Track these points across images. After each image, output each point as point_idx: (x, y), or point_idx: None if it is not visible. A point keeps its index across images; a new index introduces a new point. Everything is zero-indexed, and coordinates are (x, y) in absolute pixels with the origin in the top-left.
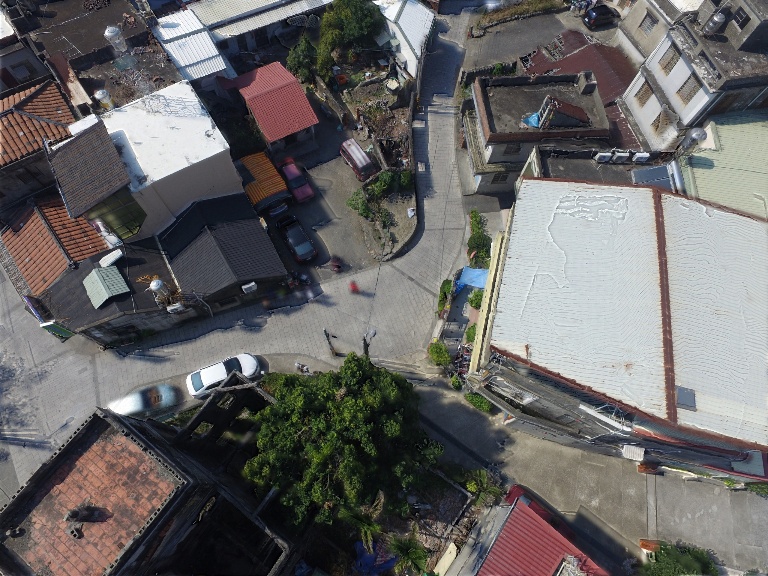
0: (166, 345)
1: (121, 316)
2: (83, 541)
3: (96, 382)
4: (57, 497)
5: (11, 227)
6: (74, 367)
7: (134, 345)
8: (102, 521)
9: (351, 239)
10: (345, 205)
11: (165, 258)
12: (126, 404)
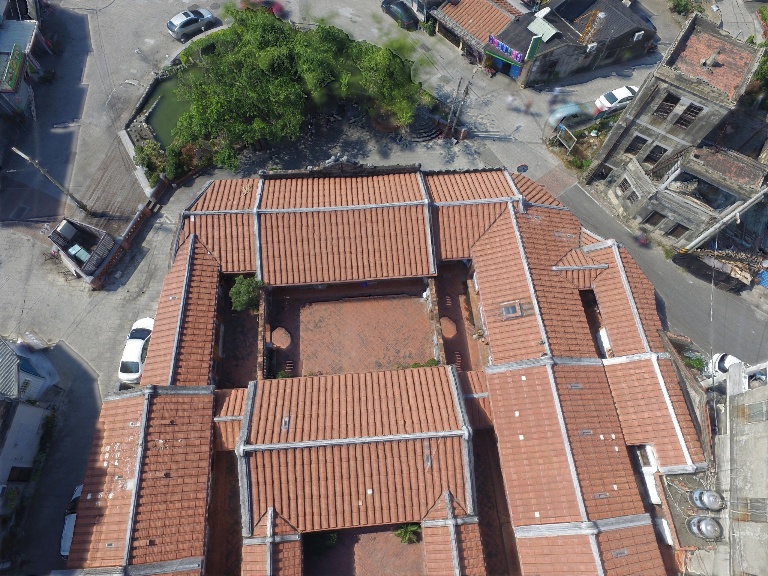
0: (567, 86)
1: (565, 46)
2: (714, 74)
3: (527, 106)
4: (686, 57)
5: (450, 2)
6: (507, 98)
7: (544, 86)
8: (720, 67)
9: (671, 28)
10: (658, 7)
11: (566, 22)
12: (554, 118)
